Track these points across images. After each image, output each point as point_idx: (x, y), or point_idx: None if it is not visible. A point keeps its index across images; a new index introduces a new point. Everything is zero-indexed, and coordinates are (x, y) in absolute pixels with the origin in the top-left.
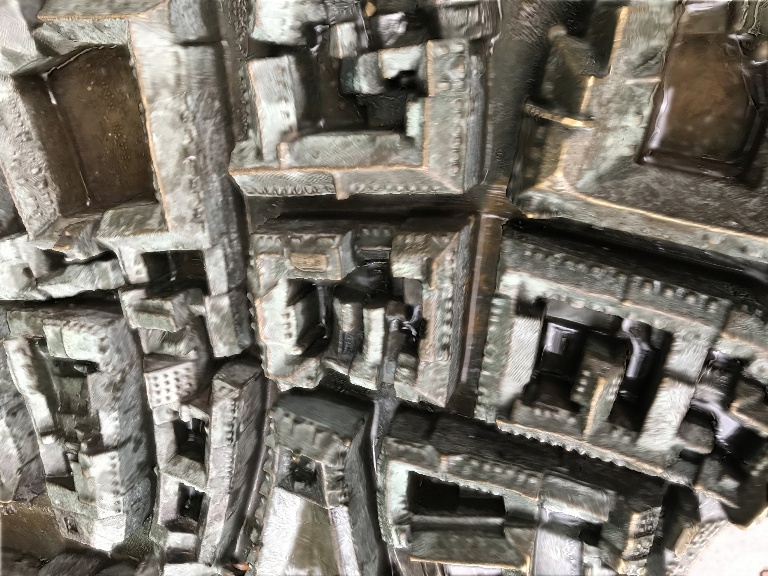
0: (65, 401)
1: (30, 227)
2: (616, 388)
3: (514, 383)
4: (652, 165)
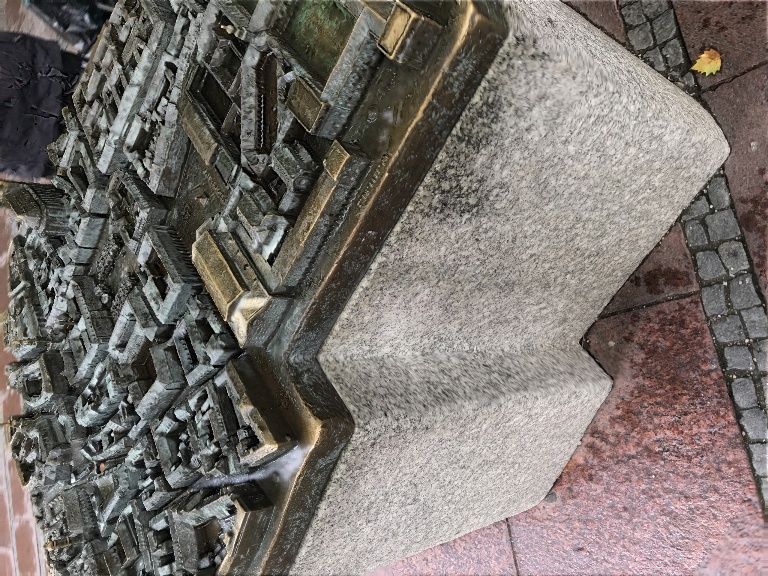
0: (102, 386)
1: (121, 361)
2: (163, 554)
3: (156, 527)
4: (196, 531)
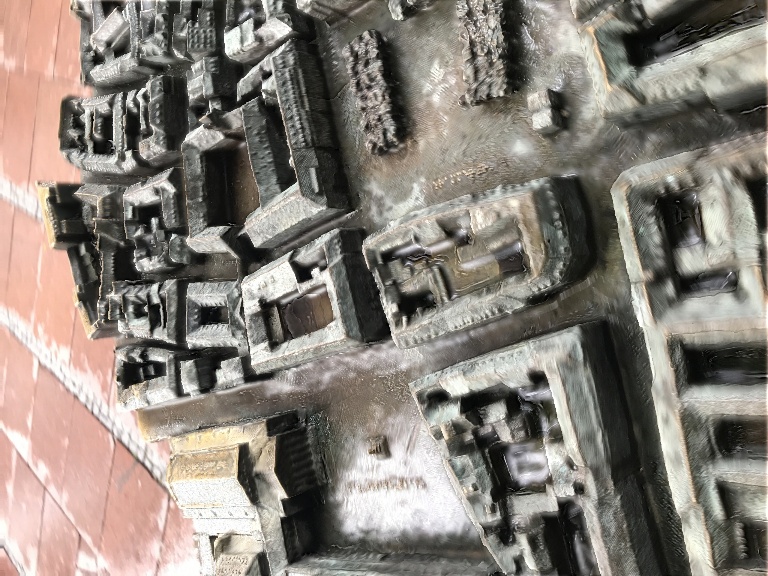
0: None
1: None
2: None
3: None
4: None
